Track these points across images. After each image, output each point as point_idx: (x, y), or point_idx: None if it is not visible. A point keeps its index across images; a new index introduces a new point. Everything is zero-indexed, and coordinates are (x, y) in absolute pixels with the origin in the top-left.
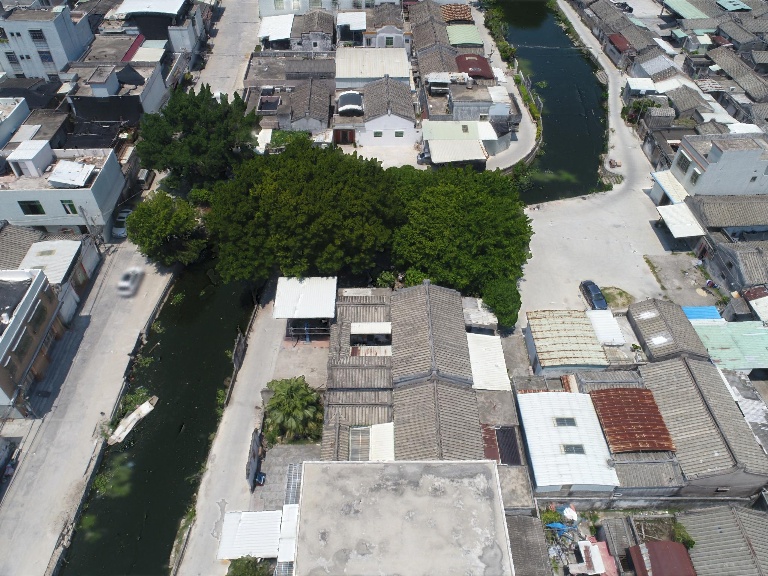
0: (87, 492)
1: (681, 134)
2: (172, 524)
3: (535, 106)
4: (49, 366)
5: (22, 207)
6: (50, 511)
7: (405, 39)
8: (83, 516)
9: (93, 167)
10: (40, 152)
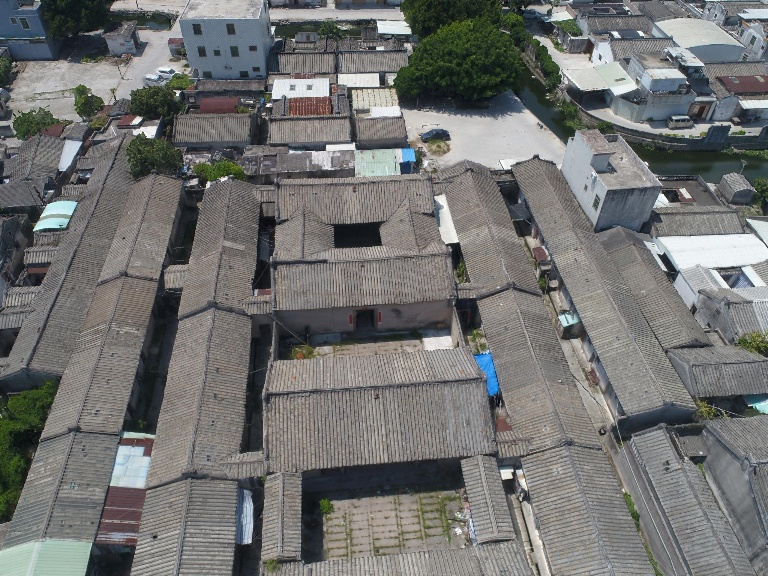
0: (302, 24)
1: (704, 198)
2: None
3: None
4: (362, 5)
5: None
6: (293, 16)
7: (763, 45)
8: None
9: None
10: None
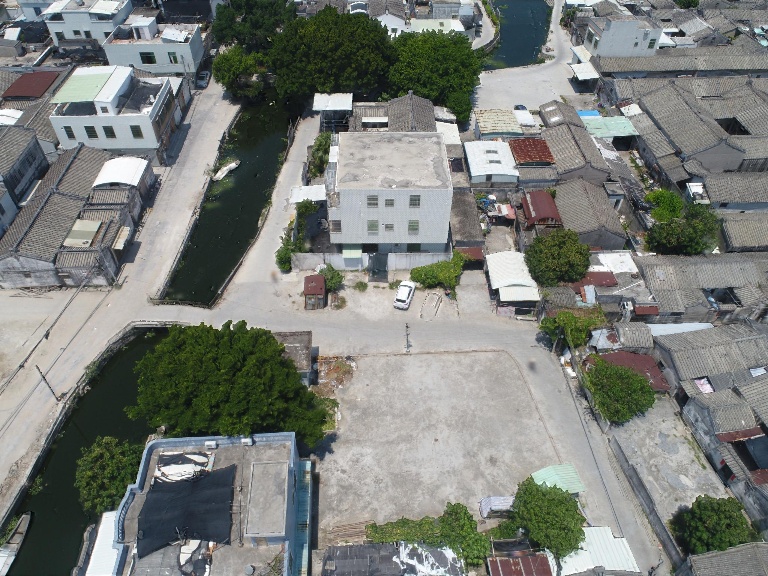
0: (204, 198)
1: None
2: (257, 211)
3: (495, 16)
4: (170, 144)
5: (142, 58)
6: (185, 202)
7: None
8: (204, 208)
9: (188, 33)
10: (152, 23)
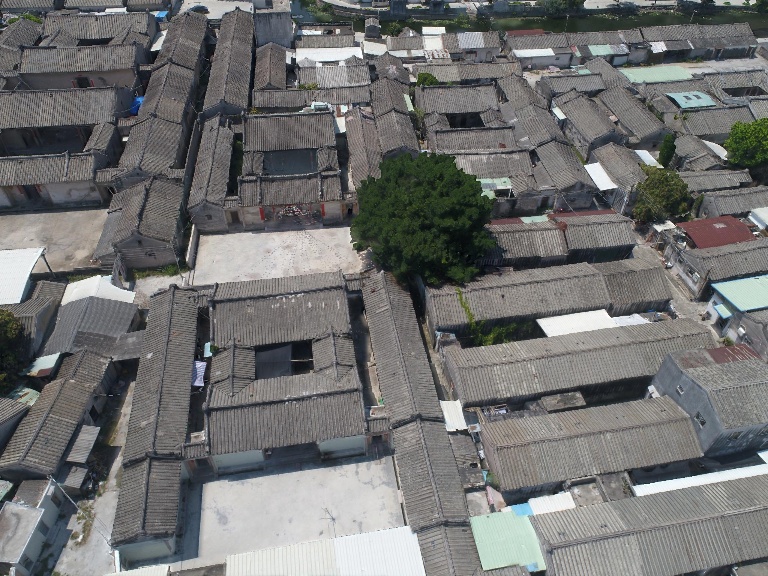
0: None
1: (346, 33)
2: None
3: None
4: None
5: None
6: None
7: None
8: None
9: None
10: None
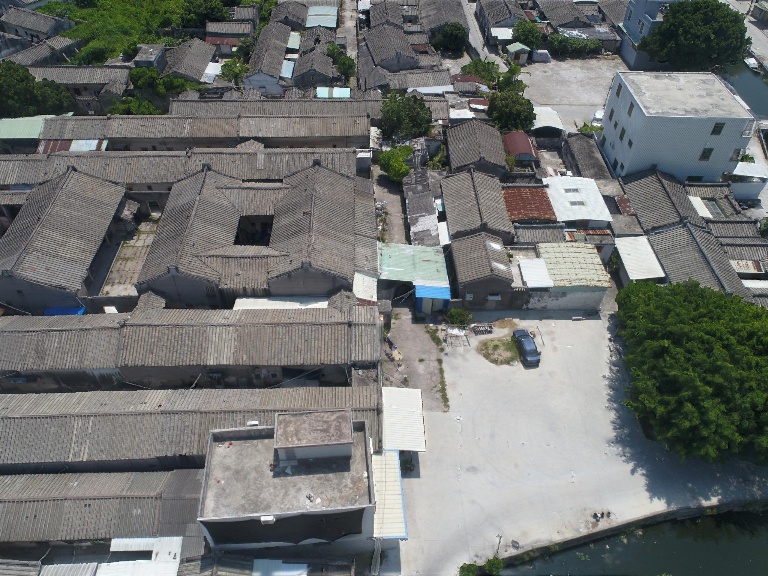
0: None
1: None
2: None
3: None
4: None
5: None
6: None
7: None
8: None
9: None
10: None
